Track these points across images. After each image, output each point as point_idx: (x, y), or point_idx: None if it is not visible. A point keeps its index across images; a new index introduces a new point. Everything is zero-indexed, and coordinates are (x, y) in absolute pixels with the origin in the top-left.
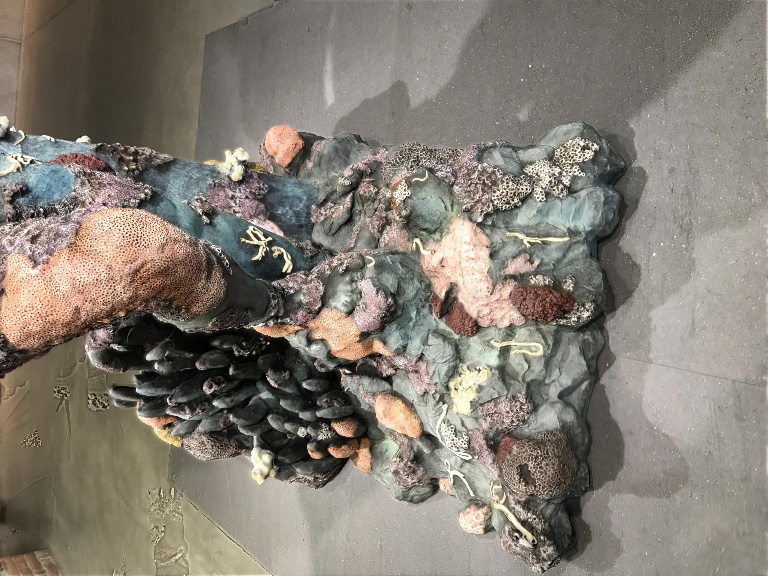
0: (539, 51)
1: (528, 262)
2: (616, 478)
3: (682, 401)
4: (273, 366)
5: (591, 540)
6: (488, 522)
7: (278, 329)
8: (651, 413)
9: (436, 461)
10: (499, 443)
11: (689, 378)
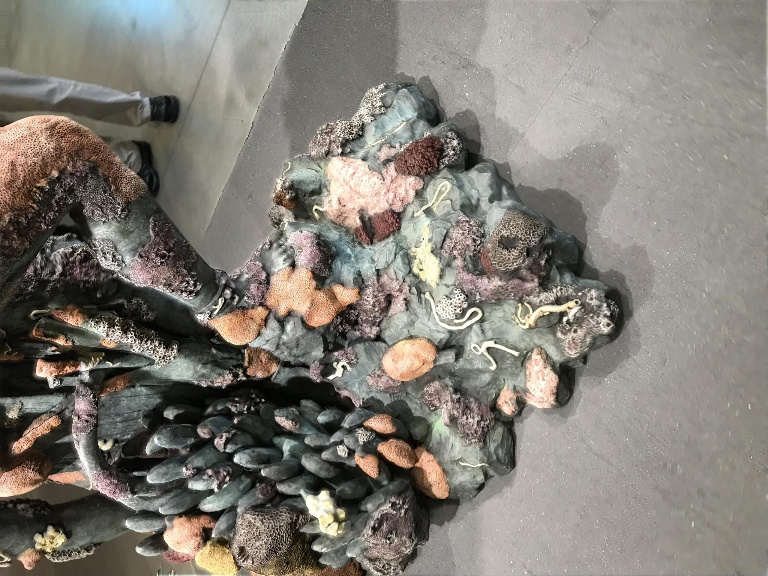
0: (329, 115)
1: (391, 148)
2: (585, 215)
3: (559, 121)
4: (276, 407)
5: (623, 276)
6: (549, 361)
7: (244, 318)
8: (555, 153)
9: (476, 379)
10: (483, 268)
11: (547, 108)
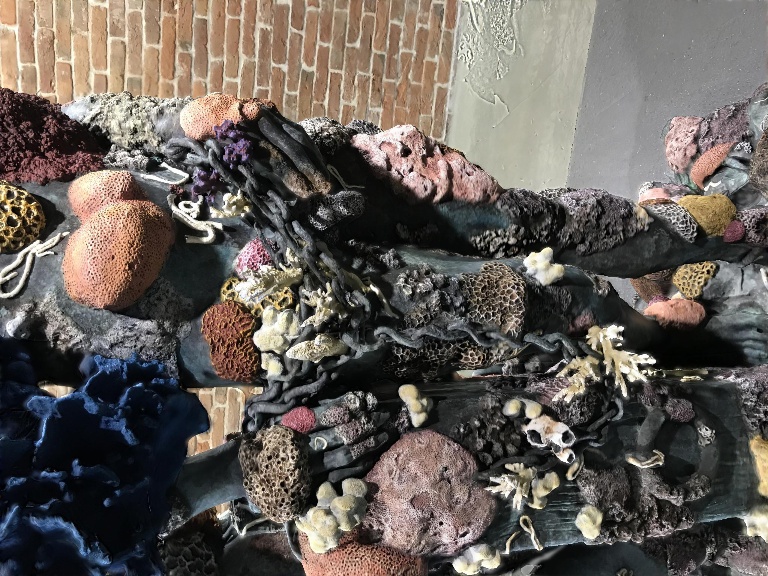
0: None
1: None
2: None
3: None
4: None
5: None
6: None
7: None
8: None
9: None
10: None
11: None
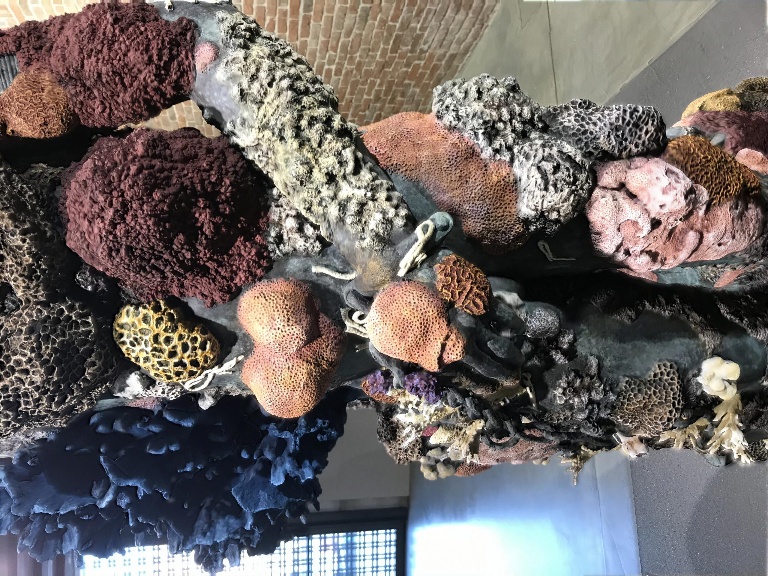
0: None
1: None
2: None
3: None
4: None
5: None
6: None
7: None
8: None
9: None
10: None
11: None
